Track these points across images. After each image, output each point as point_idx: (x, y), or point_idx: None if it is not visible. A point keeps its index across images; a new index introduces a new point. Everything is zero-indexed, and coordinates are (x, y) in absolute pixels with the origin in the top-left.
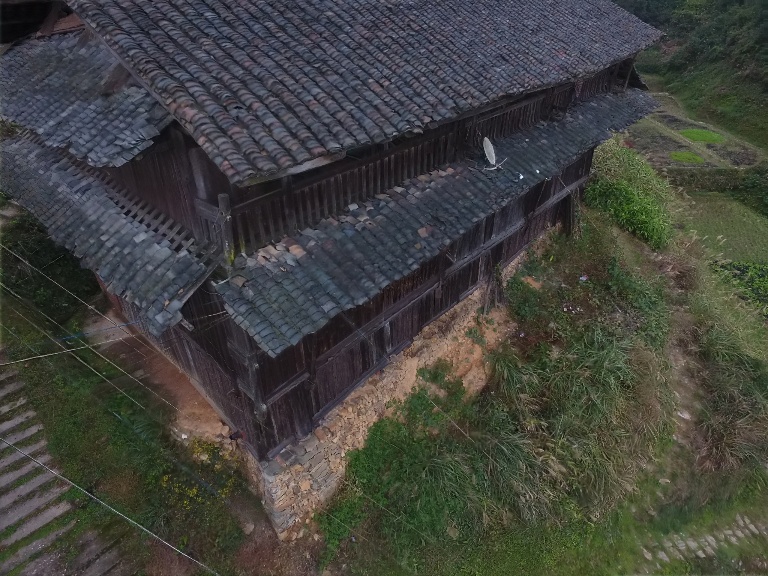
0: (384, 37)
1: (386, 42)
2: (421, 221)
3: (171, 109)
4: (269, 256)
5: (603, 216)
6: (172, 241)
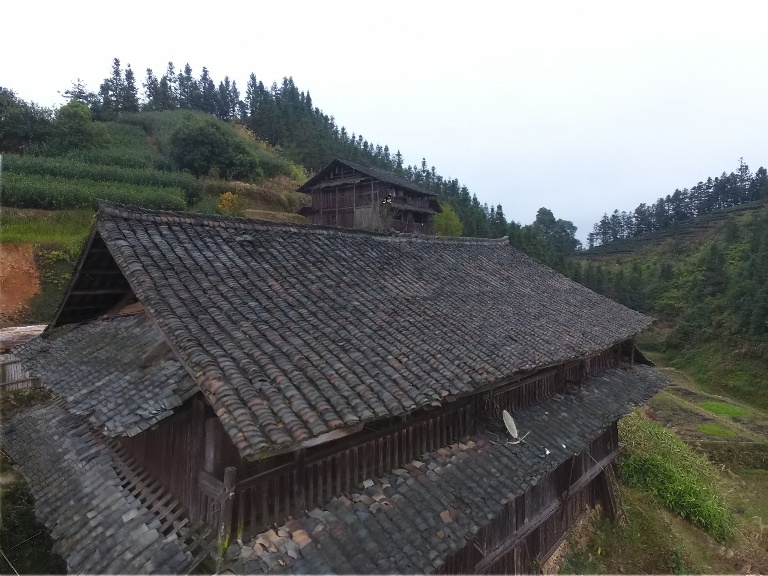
0: (403, 321)
1: (404, 325)
2: (443, 502)
3: (199, 381)
4: (268, 544)
5: (646, 497)
6: (163, 521)
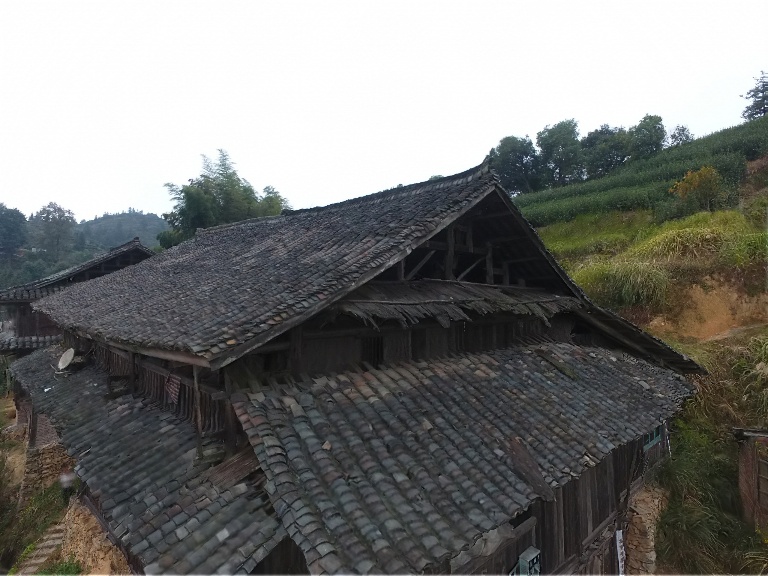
0: None
1: None
2: None
3: None
4: None
5: None
6: None
